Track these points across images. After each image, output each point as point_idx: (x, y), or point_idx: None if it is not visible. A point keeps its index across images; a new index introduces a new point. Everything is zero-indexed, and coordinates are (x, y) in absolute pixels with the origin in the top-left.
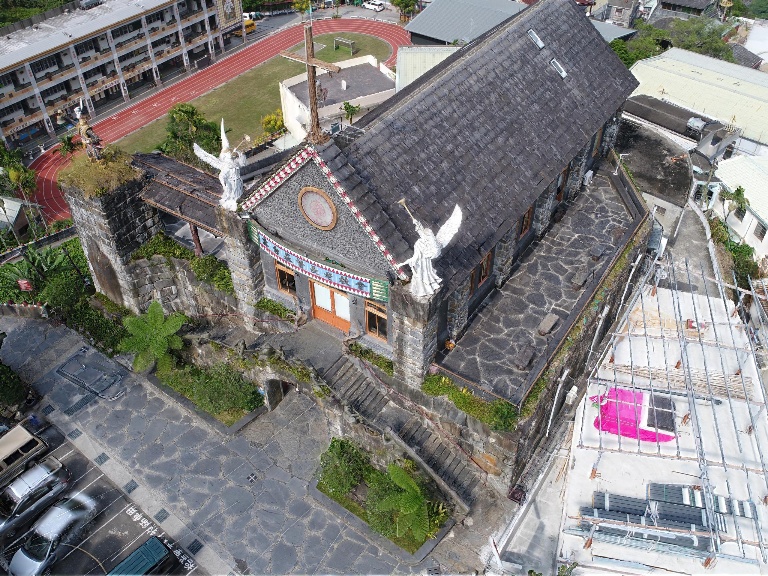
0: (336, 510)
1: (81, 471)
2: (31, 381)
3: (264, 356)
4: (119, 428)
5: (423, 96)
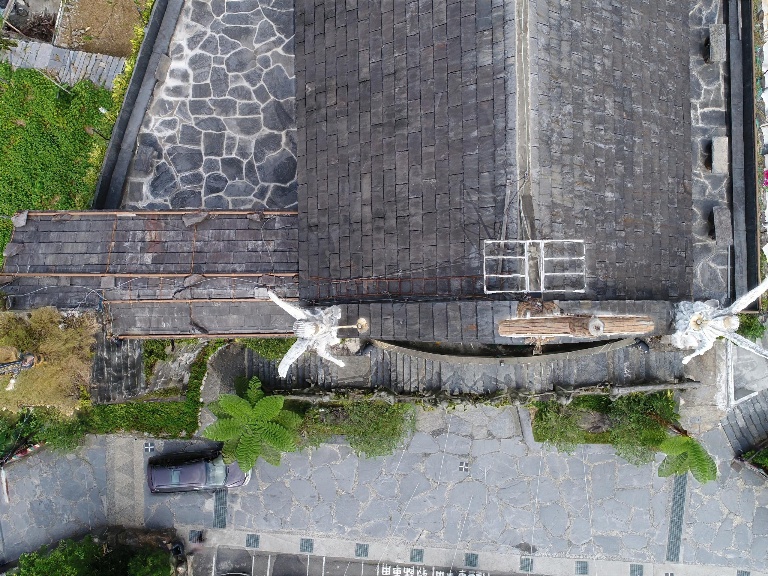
0: None
1: (301, 570)
2: (139, 520)
3: None
4: (288, 506)
5: (533, 8)
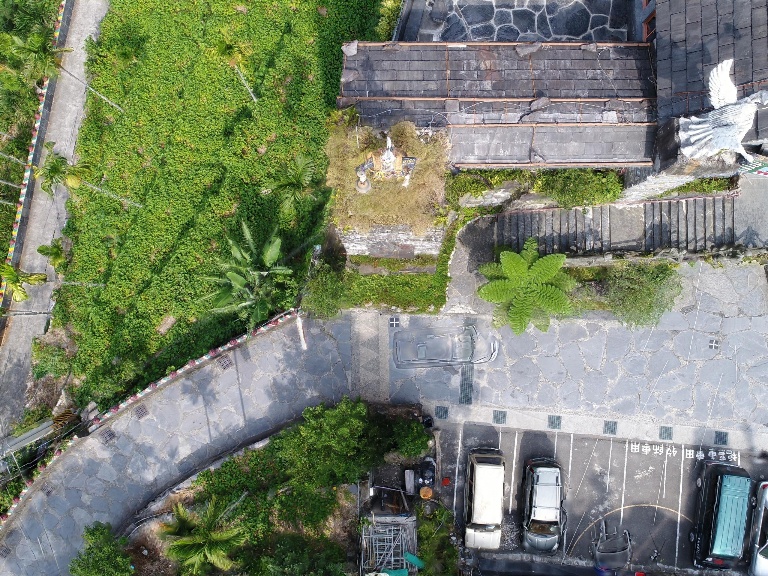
0: None
1: (549, 446)
2: (384, 396)
3: None
4: (536, 382)
5: None
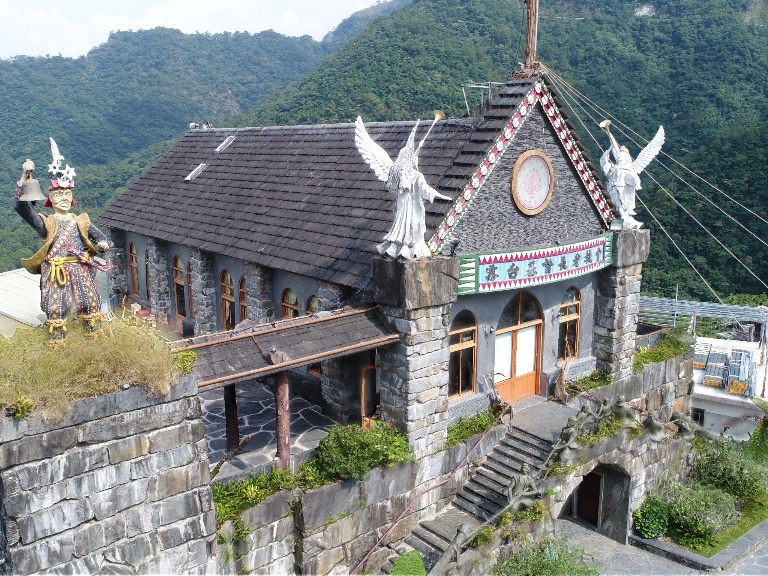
0: (743, 546)
1: None
2: None
3: (574, 444)
4: None
5: None
